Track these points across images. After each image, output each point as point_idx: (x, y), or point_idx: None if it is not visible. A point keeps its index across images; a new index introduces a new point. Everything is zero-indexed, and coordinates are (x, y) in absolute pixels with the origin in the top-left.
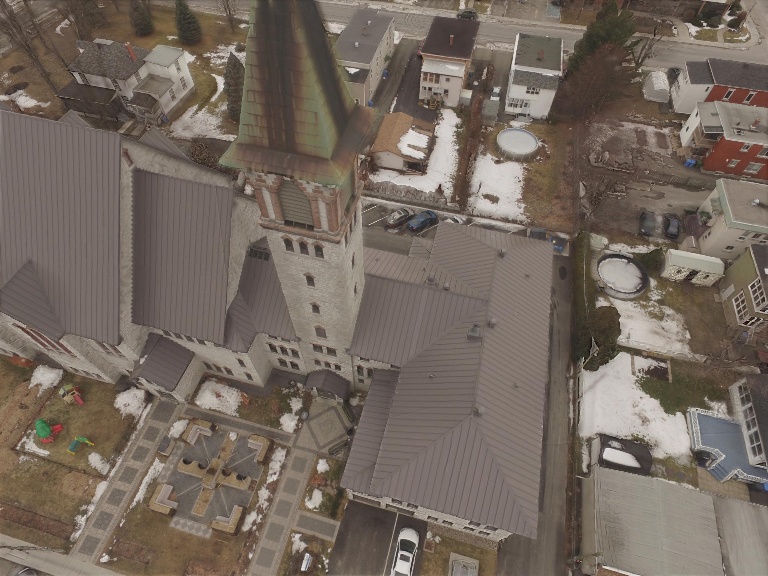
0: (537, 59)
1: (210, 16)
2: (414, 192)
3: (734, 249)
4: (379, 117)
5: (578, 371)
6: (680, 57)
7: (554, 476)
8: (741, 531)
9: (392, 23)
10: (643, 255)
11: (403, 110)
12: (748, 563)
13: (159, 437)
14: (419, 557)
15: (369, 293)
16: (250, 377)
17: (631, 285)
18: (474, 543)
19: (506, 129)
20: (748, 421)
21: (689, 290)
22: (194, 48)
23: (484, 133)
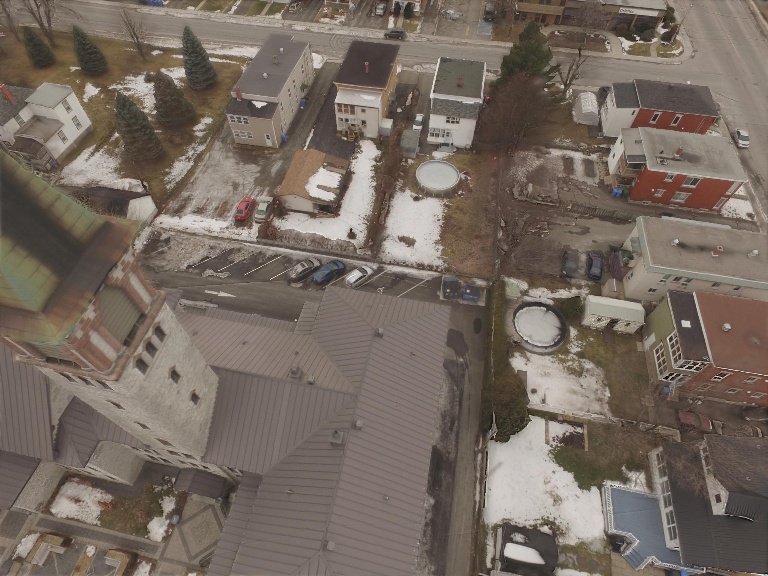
0: (457, 86)
1: (120, 43)
2: (320, 240)
3: (657, 291)
4: (293, 152)
5: (484, 446)
6: (612, 74)
7: (454, 575)
8: None
9: (307, 49)
10: (563, 301)
11: (319, 143)
12: None
13: (3, 558)
14: None
15: (225, 390)
16: (113, 478)
17: (549, 337)
18: None
19: (426, 162)
20: (665, 496)
21: (611, 339)
22: (99, 80)
23: (404, 166)
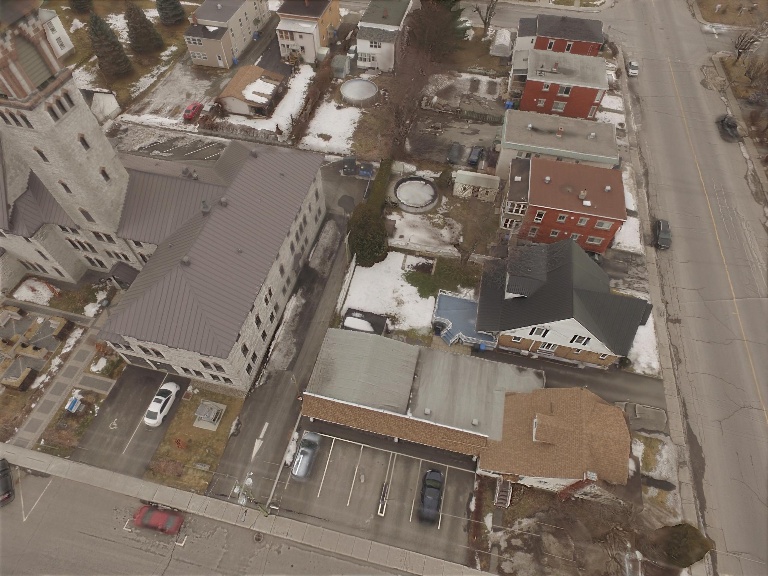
0: (382, 17)
1: None
2: (247, 129)
3: None
4: None
5: (348, 264)
6: None
7: (310, 345)
8: (436, 371)
9: None
10: None
11: (265, 66)
12: (433, 393)
13: None
14: (177, 404)
15: (134, 185)
16: (61, 273)
17: (422, 201)
18: (226, 393)
19: (351, 79)
20: None
21: (474, 205)
22: (85, 17)
23: (334, 84)
